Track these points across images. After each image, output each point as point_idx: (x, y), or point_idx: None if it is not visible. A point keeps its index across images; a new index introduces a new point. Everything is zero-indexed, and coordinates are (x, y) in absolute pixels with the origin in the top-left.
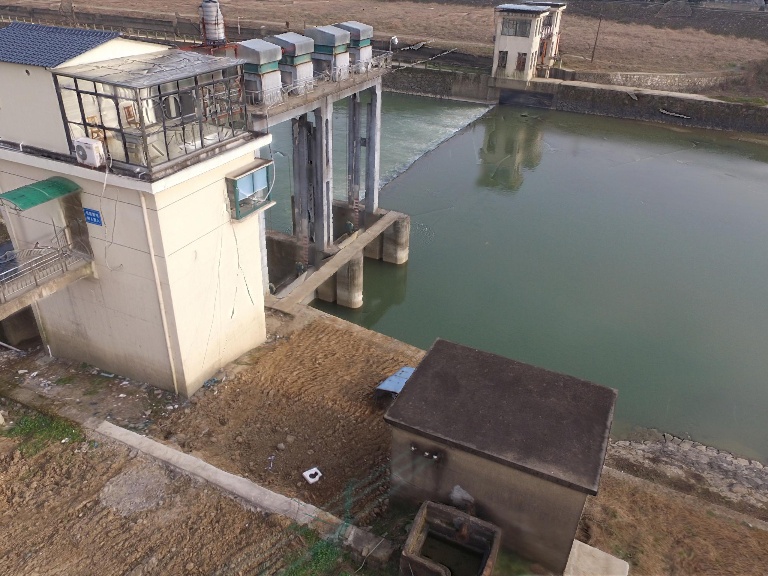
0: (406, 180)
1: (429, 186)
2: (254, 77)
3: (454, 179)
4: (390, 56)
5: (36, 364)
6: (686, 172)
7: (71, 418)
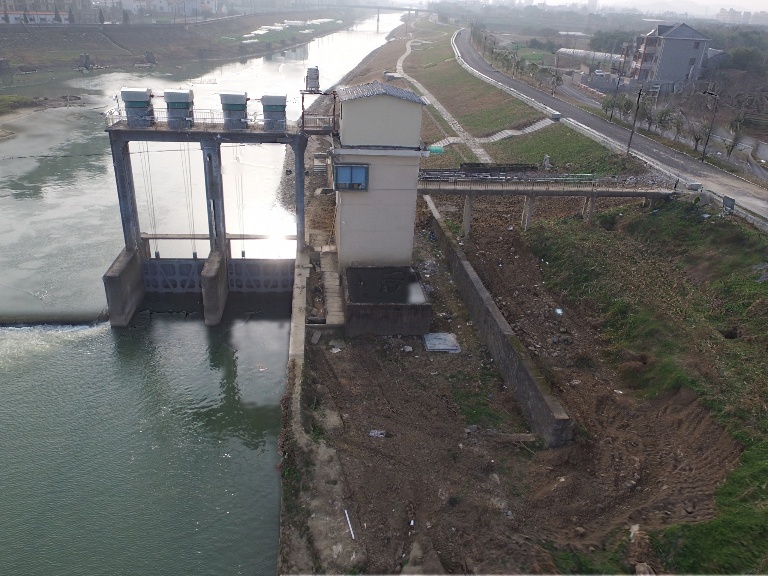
0: None
1: None
2: None
3: None
4: (122, 110)
5: None
6: None
7: None
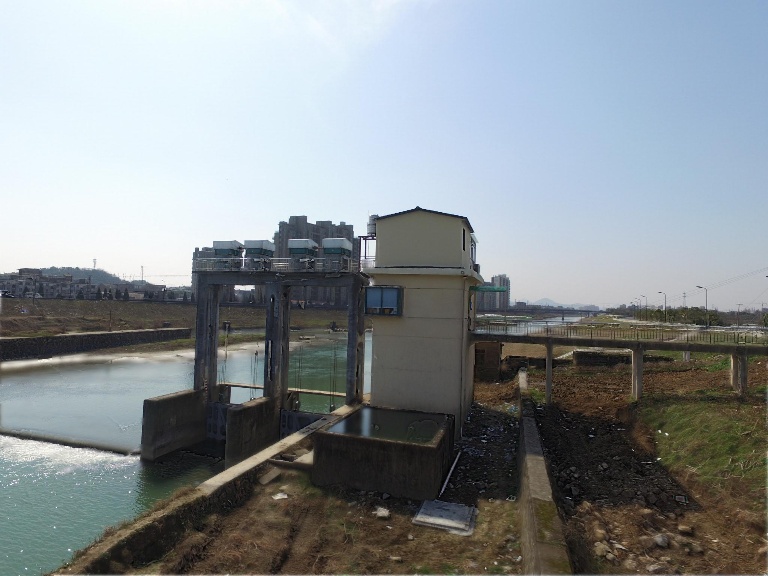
0: (2, 424)
1: (34, 419)
2: (348, 258)
3: (26, 412)
4: None
5: (473, 440)
6: (101, 372)
7: (527, 390)
